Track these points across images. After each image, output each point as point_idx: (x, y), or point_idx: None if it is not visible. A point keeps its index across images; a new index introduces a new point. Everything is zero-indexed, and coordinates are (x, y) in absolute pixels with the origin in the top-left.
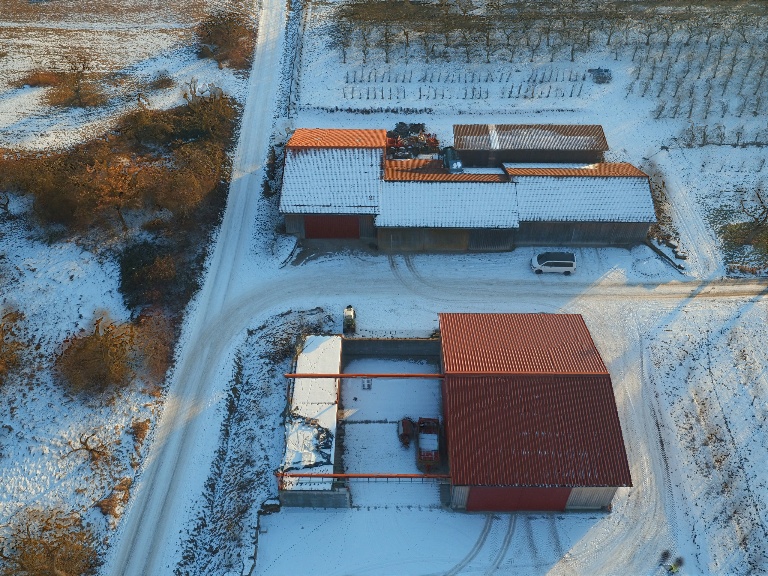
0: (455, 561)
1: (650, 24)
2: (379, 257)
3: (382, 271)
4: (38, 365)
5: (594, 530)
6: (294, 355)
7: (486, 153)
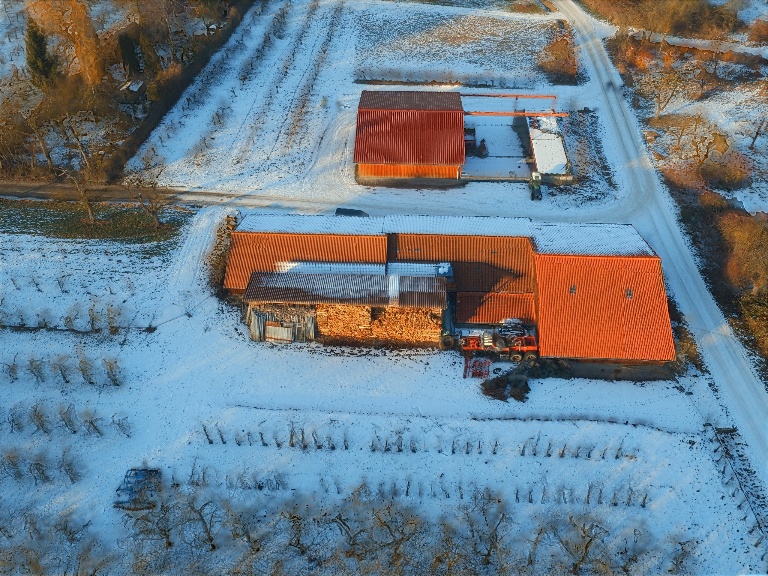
0: None
1: None
2: None
3: None
4: (763, 177)
5: None
6: None
7: None
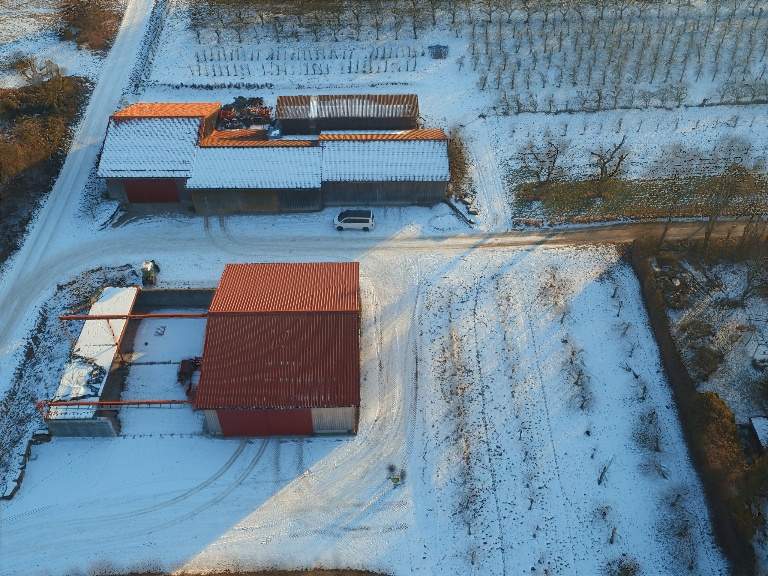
0: (202, 479)
1: (489, 3)
2: (195, 218)
3: (196, 231)
4: None
5: (337, 450)
6: (88, 304)
7: (306, 122)
